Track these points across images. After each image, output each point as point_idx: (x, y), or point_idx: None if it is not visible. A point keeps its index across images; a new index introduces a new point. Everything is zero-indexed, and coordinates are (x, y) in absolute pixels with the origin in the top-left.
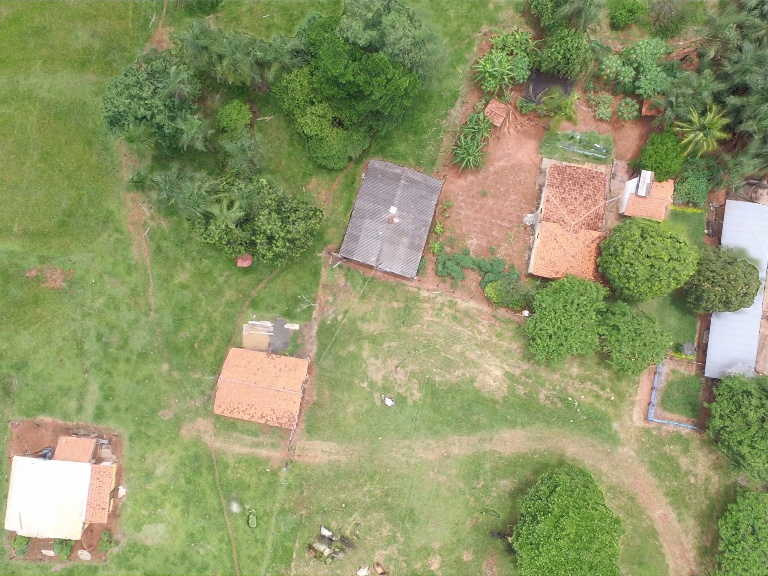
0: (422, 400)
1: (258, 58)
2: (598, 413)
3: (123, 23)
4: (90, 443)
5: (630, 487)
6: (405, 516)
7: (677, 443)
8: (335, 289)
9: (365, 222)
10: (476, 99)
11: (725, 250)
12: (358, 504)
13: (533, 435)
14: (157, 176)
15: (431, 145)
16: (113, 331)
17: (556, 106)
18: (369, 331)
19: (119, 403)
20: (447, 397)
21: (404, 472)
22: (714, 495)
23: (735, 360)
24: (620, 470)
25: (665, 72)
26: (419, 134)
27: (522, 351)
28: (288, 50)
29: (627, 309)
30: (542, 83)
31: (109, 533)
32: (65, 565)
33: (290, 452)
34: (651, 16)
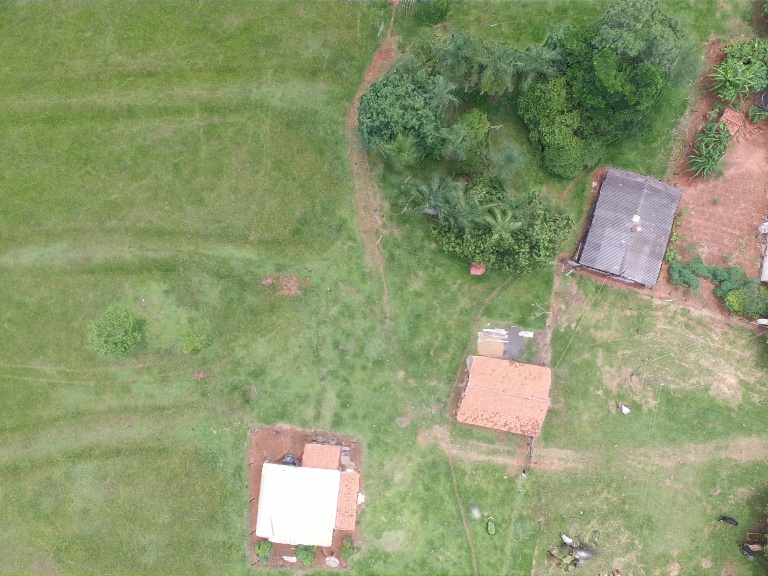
0: (657, 408)
1: (518, 68)
2: None
3: (352, 32)
4: (336, 450)
5: None
6: (643, 523)
7: None
8: (567, 297)
9: (606, 231)
10: (705, 108)
11: None
12: (596, 511)
13: None
14: (422, 186)
15: (661, 153)
16: (349, 339)
17: None
18: (603, 339)
19: (356, 410)
20: (682, 405)
21: (641, 480)
22: None
23: None
24: None
25: None
26: (649, 143)
27: (755, 359)
28: (546, 60)
29: None
30: None
31: (350, 539)
32: (306, 571)
33: (526, 459)
34: None
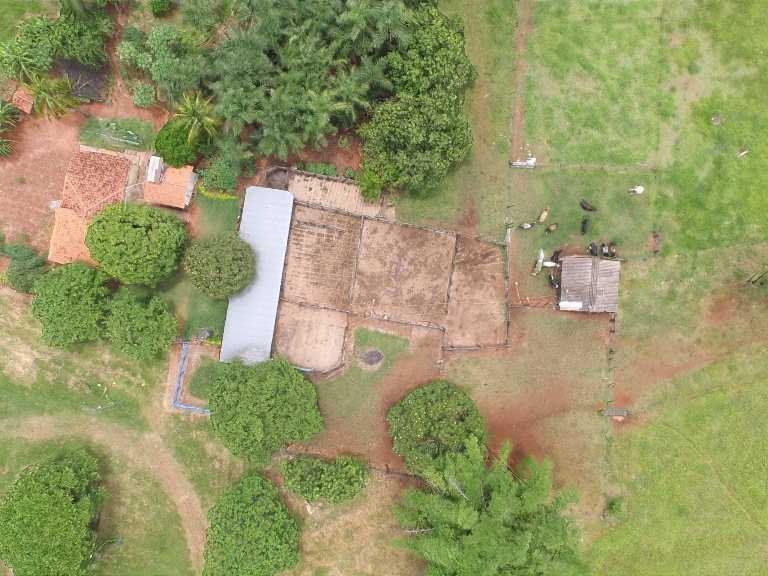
0: None
1: None
2: (126, 399)
3: None
4: None
5: (155, 473)
6: None
7: (204, 429)
8: None
9: None
10: None
11: (241, 236)
12: None
13: (61, 422)
14: None
15: None
16: None
17: (92, 93)
18: None
19: None
20: None
21: None
22: (238, 480)
23: (249, 345)
24: (146, 456)
25: (180, 58)
26: None
27: None
28: None
29: (126, 294)
30: (74, 70)
31: None
32: None
33: None
34: (192, 3)
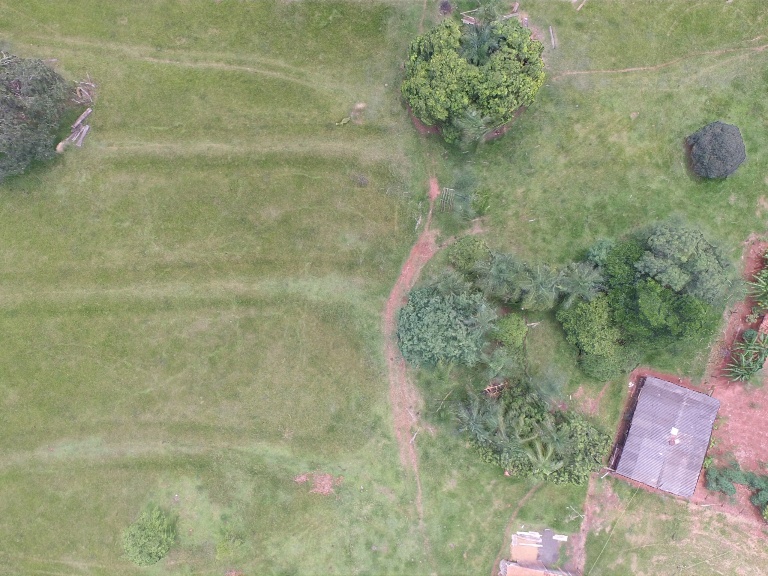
0: None
1: (560, 292)
2: None
3: (390, 225)
4: None
5: None
6: None
7: None
8: (602, 499)
9: (644, 441)
10: (744, 309)
11: None
12: None
13: None
14: (461, 411)
15: (699, 355)
16: (382, 539)
17: None
18: (637, 544)
19: None
20: None
21: None
22: None
23: None
24: None
25: None
26: (687, 344)
27: None
28: (588, 282)
29: None
30: None
31: None
32: None
33: None
34: None
